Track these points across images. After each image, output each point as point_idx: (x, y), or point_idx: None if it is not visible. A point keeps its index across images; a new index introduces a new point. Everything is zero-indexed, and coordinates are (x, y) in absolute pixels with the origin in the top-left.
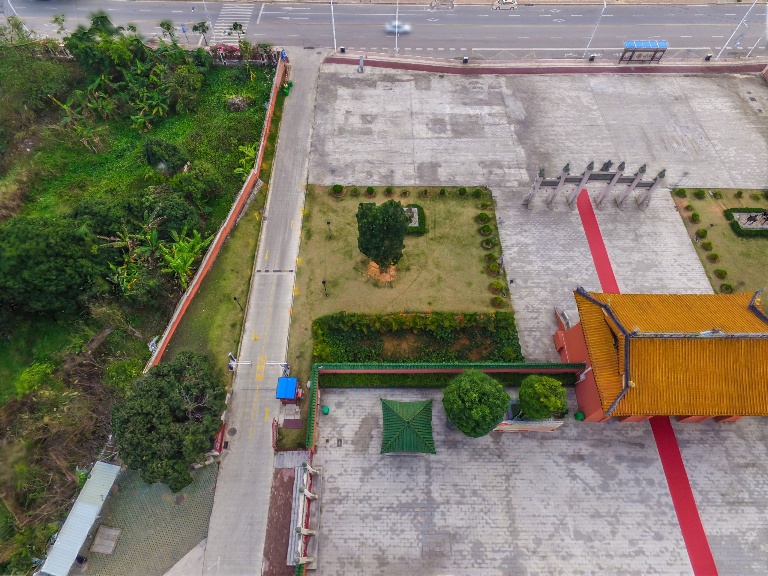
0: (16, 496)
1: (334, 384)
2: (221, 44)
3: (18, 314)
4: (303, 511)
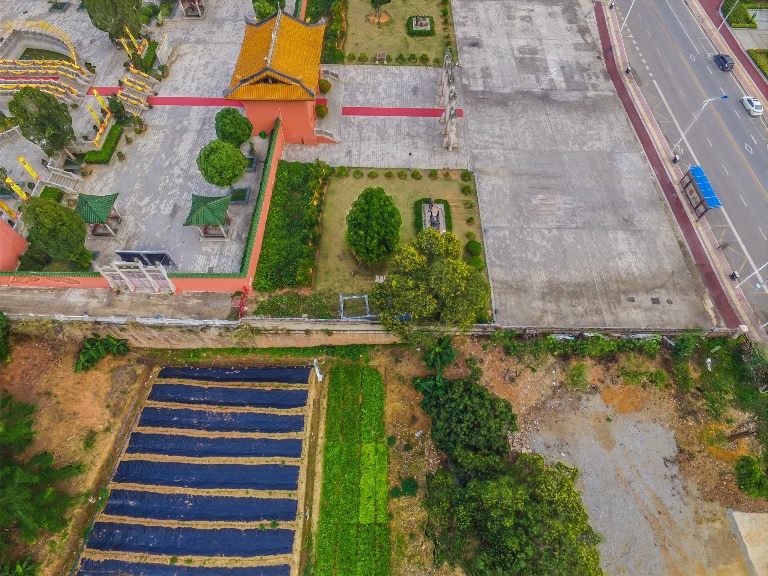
0: None
1: None
2: None
3: None
4: None
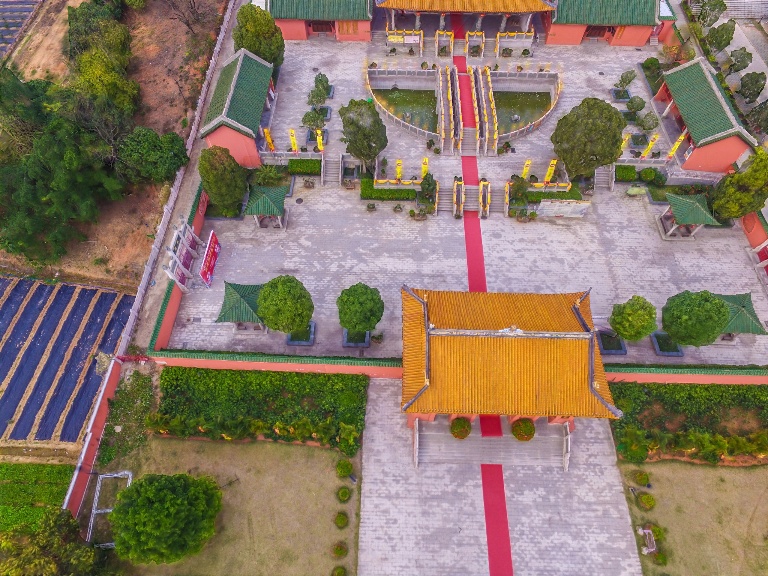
0: None
1: None
2: None
3: None
4: None
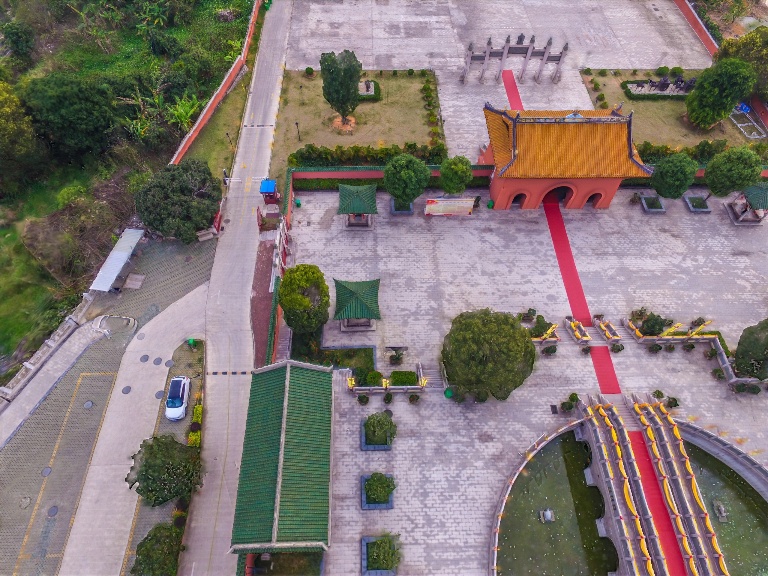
0: (62, 268)
1: (304, 185)
2: None
3: (53, 159)
4: (280, 245)
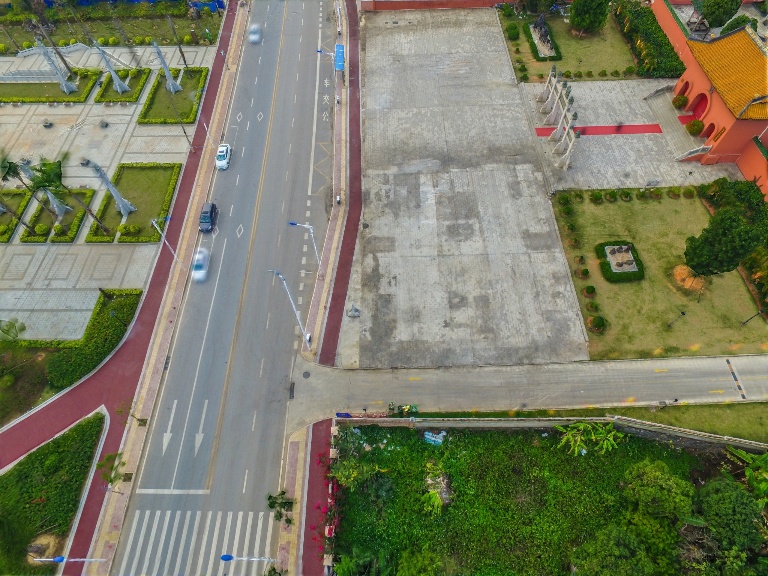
0: None
1: None
2: (318, 532)
3: None
4: None
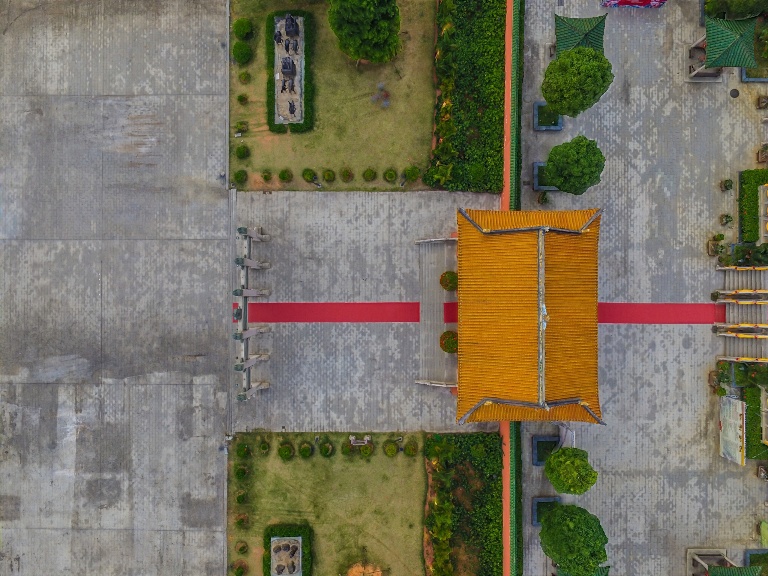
0: None
1: None
2: None
3: None
4: None
